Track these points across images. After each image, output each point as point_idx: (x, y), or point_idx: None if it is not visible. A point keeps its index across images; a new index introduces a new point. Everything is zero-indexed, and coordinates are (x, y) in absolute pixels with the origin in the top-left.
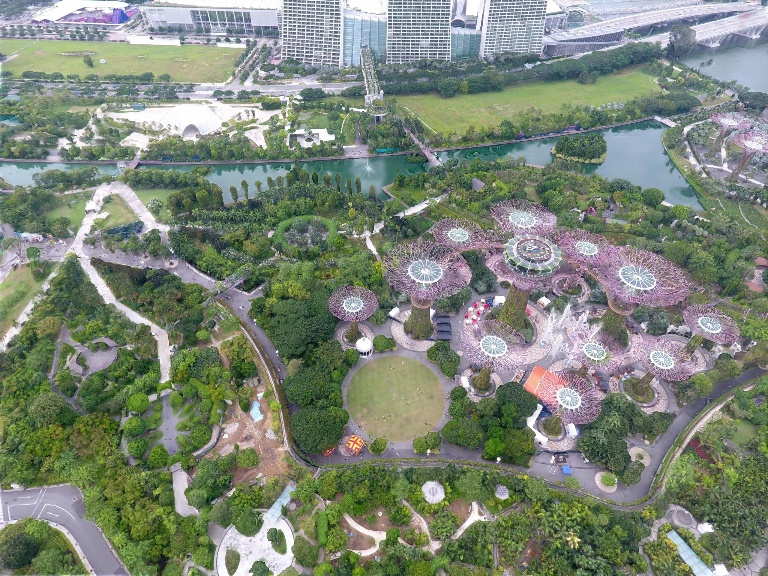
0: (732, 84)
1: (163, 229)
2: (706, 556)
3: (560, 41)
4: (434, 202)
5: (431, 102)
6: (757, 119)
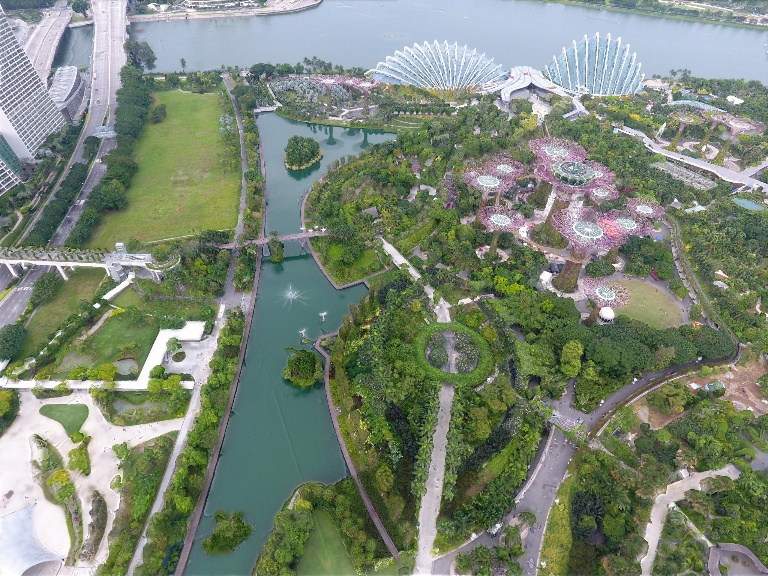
0: (223, 69)
1: (428, 567)
2: (694, 204)
3: (64, 101)
4: (405, 242)
5: (128, 222)
6: (283, 80)
